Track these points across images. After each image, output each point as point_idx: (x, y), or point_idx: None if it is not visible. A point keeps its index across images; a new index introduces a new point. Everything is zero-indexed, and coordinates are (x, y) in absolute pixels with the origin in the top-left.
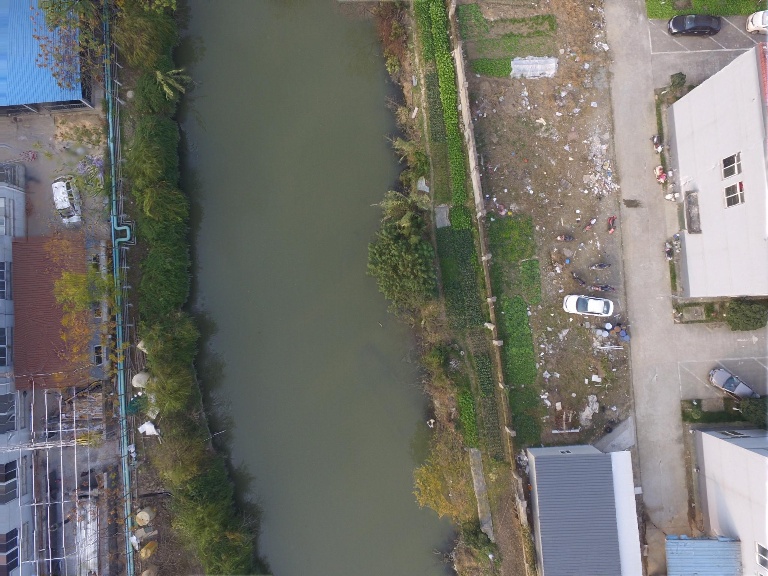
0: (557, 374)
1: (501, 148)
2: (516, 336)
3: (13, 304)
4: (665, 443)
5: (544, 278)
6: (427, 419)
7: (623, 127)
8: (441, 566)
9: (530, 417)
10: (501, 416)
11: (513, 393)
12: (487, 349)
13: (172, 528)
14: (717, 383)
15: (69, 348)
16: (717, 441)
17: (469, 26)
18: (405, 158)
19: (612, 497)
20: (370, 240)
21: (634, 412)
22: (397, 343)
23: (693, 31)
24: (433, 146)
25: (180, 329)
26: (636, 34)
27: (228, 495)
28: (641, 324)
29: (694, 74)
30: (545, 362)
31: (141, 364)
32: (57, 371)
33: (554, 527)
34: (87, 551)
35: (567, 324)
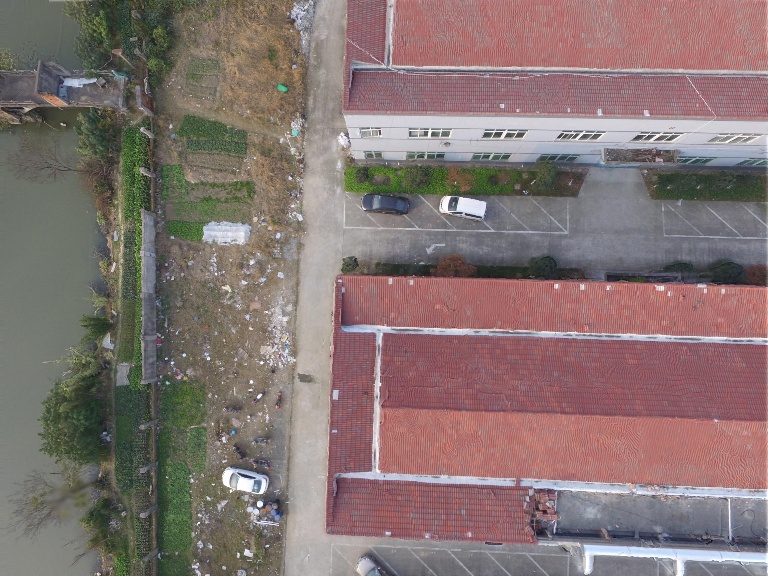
0: (210, 545)
1: (185, 312)
2: (175, 503)
3: None
4: None
5: (210, 447)
6: (94, 572)
7: (307, 300)
8: None
9: None
10: None
11: (165, 560)
12: None
13: None
14: (361, 572)
15: None
16: None
17: (171, 187)
18: (102, 310)
19: None
20: (48, 394)
21: None
22: (74, 493)
23: (380, 211)
24: (123, 303)
25: None
26: (331, 206)
27: None
28: (300, 502)
29: (383, 251)
30: (200, 532)
31: None
32: None
33: None
34: None
35: (227, 495)
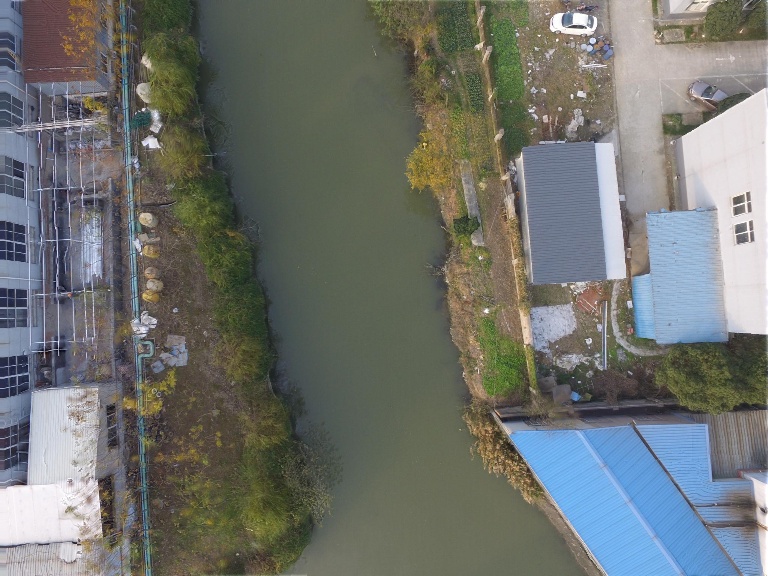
0: (544, 90)
1: None
2: (505, 55)
3: (22, 19)
4: (647, 154)
5: (531, 2)
6: None
7: None
8: (433, 279)
9: (518, 130)
10: (490, 130)
11: (502, 107)
12: (477, 70)
13: (174, 235)
14: (696, 93)
15: (77, 18)
16: (695, 131)
17: None
18: None
19: (596, 182)
20: None
21: (617, 126)
22: (391, 72)
23: None
24: None
25: (183, 39)
26: None
27: (228, 205)
28: (624, 45)
29: None
30: (532, 79)
31: (145, 79)
32: (64, 66)
33: (541, 211)
34: (92, 251)
35: (553, 44)
